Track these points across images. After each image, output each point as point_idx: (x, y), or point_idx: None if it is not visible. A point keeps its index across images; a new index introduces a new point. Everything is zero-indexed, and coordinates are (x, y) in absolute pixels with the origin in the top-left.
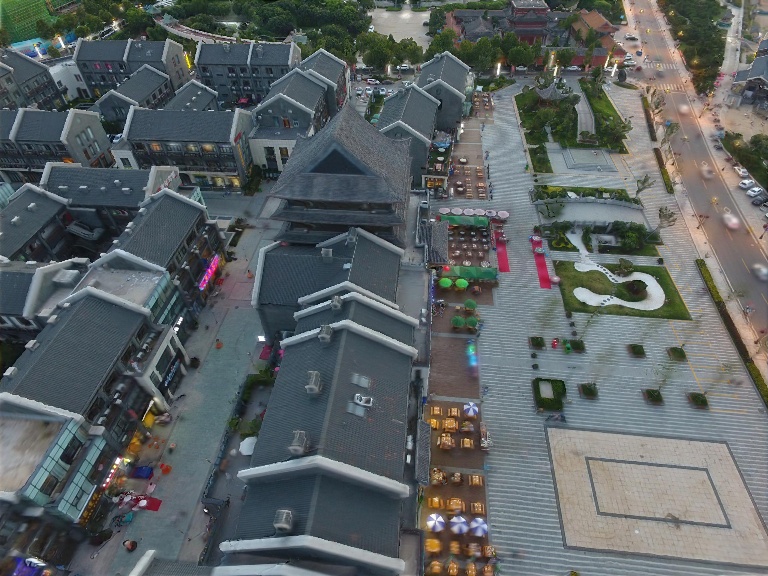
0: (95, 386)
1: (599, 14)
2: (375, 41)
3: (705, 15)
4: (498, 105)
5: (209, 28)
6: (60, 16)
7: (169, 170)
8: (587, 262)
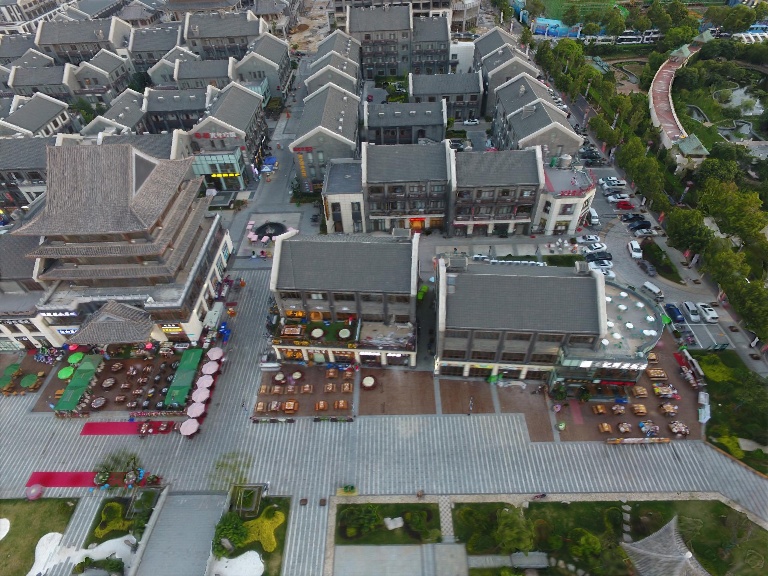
0: (0, 167)
1: None
2: (727, 208)
3: None
4: (638, 455)
5: (705, 81)
6: (608, 9)
7: (229, 129)
8: (54, 556)
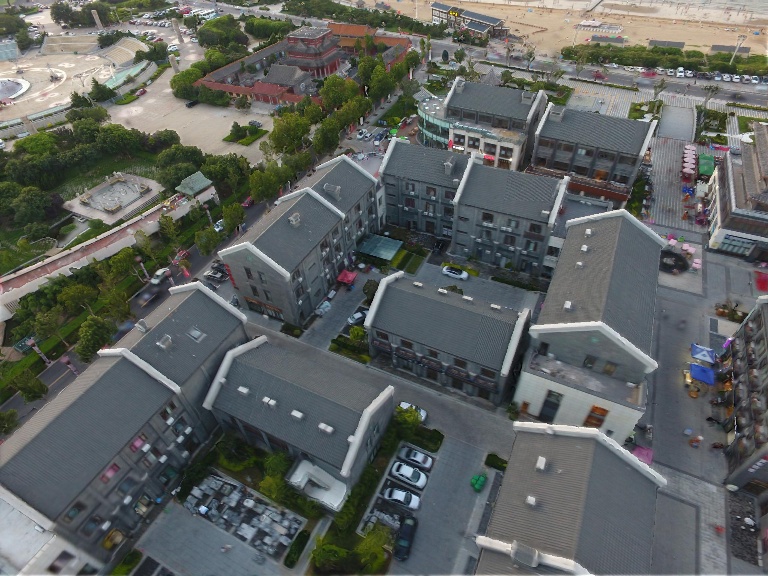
0: None
1: (345, 24)
2: (299, 124)
3: (344, 8)
4: None
5: None
6: None
7: None
8: (740, 137)
